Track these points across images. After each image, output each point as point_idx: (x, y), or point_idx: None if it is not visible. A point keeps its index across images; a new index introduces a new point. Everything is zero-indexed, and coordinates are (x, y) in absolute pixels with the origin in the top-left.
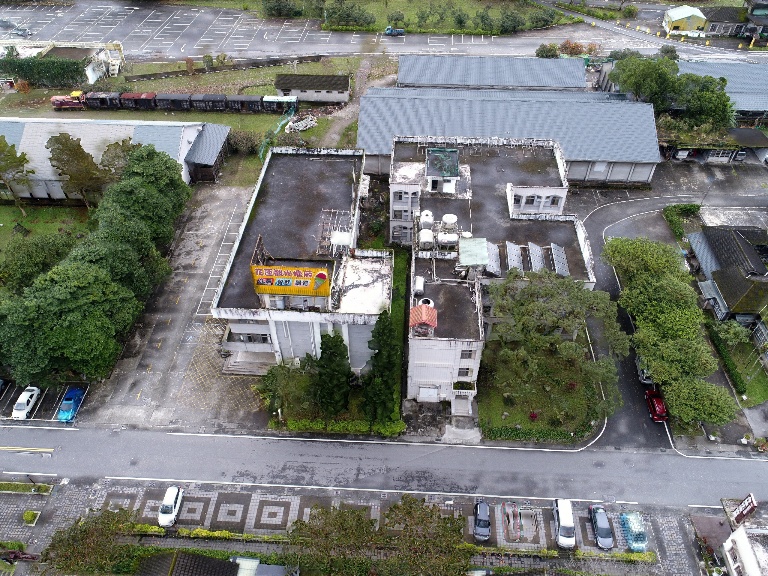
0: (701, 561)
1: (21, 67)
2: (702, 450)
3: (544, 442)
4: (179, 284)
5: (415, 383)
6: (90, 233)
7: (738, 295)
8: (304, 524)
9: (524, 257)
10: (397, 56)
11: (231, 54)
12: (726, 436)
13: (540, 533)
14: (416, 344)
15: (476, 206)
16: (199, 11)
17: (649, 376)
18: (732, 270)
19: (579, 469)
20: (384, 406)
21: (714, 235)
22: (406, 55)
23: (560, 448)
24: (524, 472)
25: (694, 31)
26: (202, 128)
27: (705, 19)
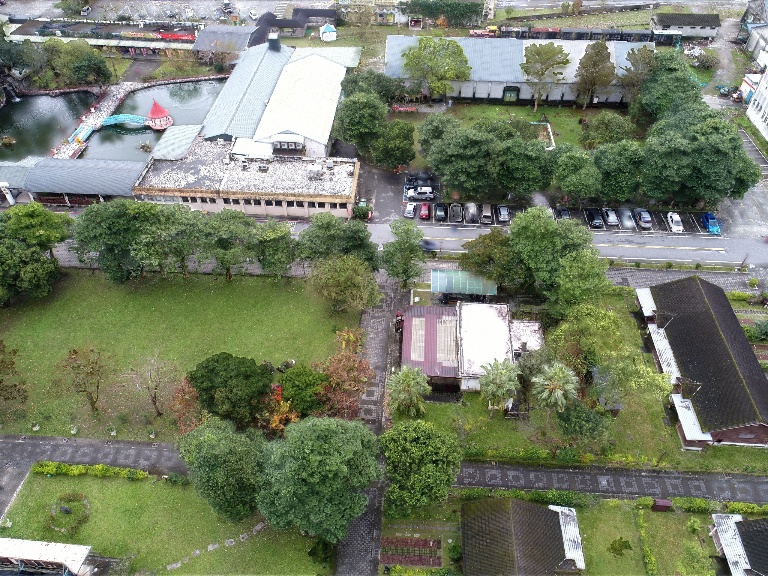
0: None
1: (429, 8)
2: None
3: None
4: None
5: None
6: (681, 106)
7: None
8: None
9: None
10: (719, 5)
11: None
12: None
13: None
14: None
15: None
16: None
17: None
18: None
19: None
20: None
21: None
22: None
23: None
24: None
25: None
26: None
27: None
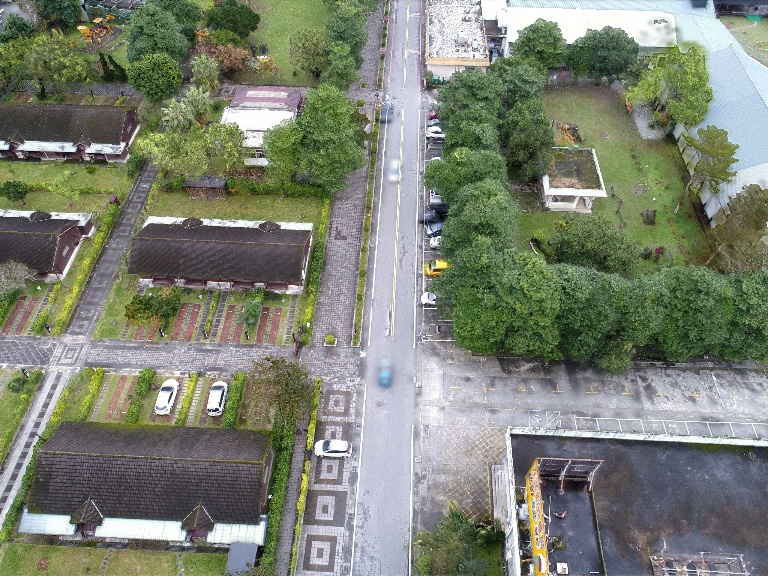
0: None
1: None
2: None
3: None
4: (618, 387)
5: None
6: None
7: None
8: None
9: None
10: None
11: None
12: None
13: None
14: None
15: None
16: None
17: None
18: None
19: None
20: None
21: None
22: None
23: None
24: None
25: None
26: None
27: None
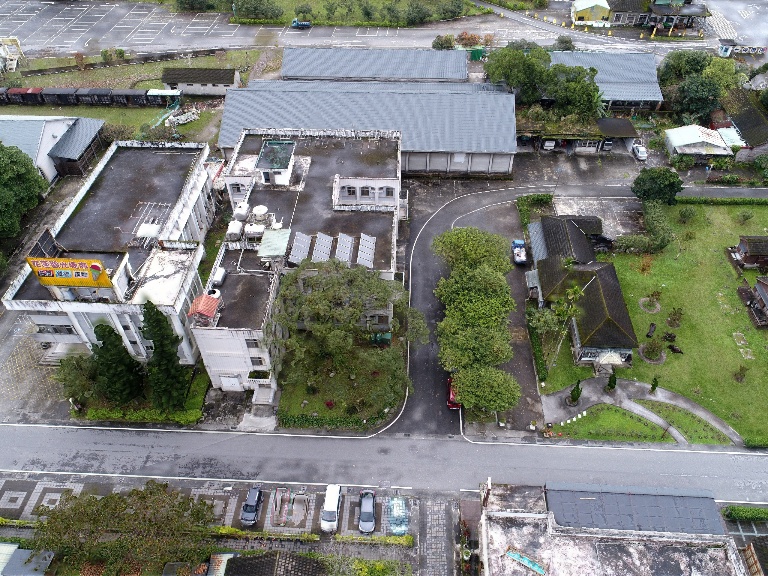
0: (458, 544)
1: None
2: (489, 436)
3: (336, 429)
4: None
5: (215, 372)
6: None
7: (553, 284)
8: (46, 509)
9: (334, 248)
10: None
11: (133, 48)
12: (517, 422)
13: (308, 518)
14: (200, 334)
15: (304, 198)
16: (114, 5)
17: (441, 364)
18: (554, 259)
19: (363, 455)
20: (170, 395)
21: (549, 225)
22: (291, 48)
23: (351, 435)
24: (309, 459)
25: (599, 21)
26: (75, 122)
27: (609, 9)
